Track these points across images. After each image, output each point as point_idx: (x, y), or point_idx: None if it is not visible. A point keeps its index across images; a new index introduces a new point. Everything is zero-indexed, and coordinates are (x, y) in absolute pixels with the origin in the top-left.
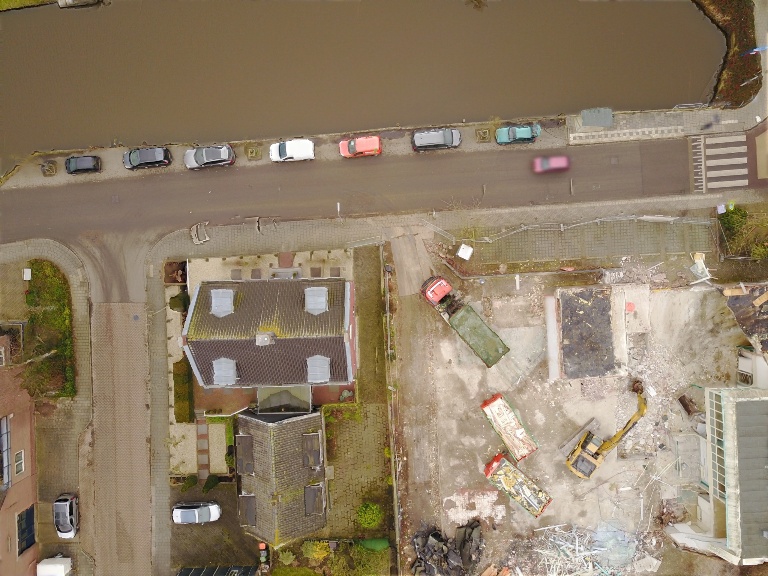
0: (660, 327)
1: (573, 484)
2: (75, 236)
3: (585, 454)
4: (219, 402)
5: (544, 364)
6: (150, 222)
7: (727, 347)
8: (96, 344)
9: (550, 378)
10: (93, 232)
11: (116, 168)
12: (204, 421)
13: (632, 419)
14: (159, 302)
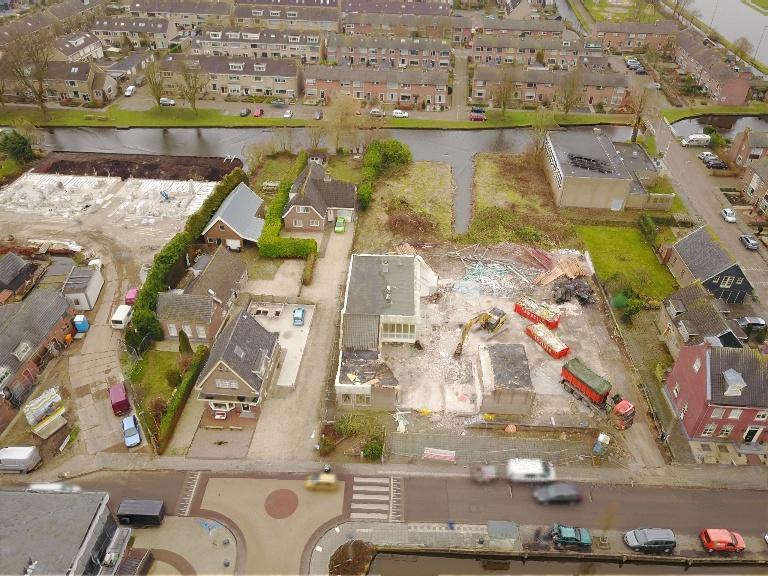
0: (434, 390)
1: None
2: None
3: None
4: None
5: None
6: None
7: None
8: None
9: None
10: None
11: None
12: None
13: None
14: None
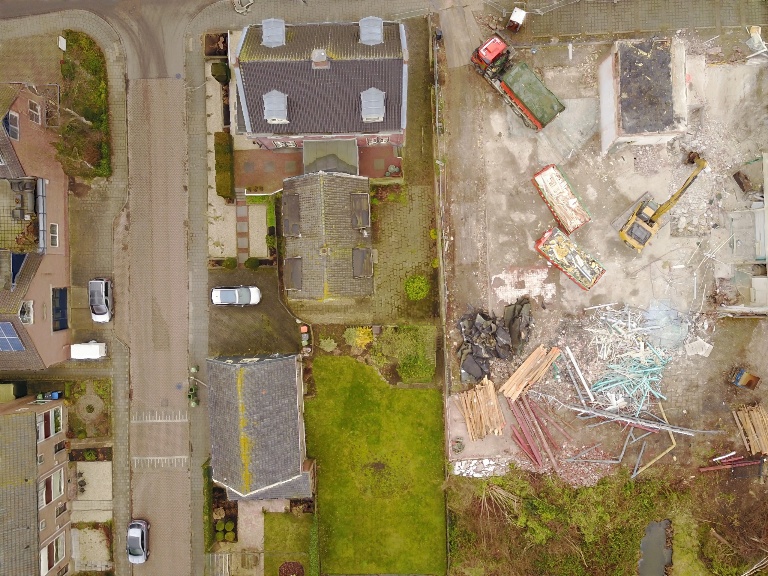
0: (715, 103)
1: (625, 262)
2: (112, 7)
3: (640, 221)
4: (260, 180)
5: (597, 137)
6: None
7: None
8: (132, 123)
9: (603, 150)
10: (130, 3)
11: None
12: (244, 202)
13: (691, 176)
14: (198, 77)
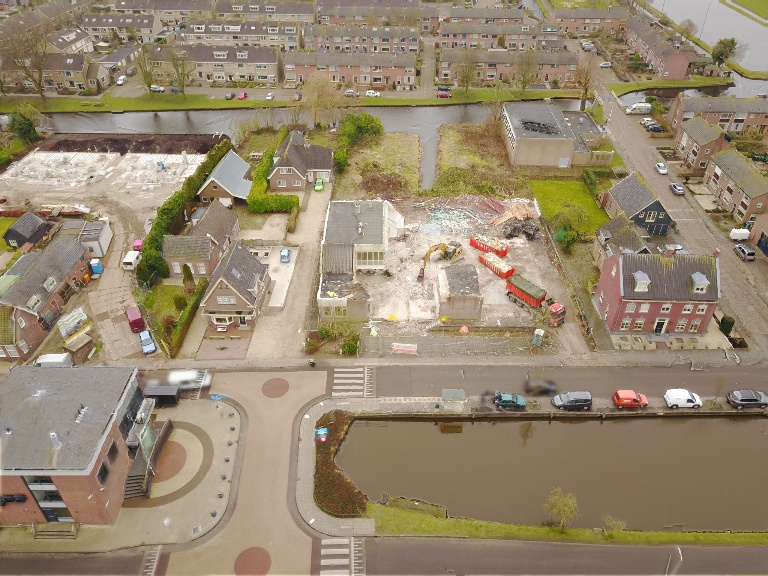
0: (401, 306)
1: None
2: None
3: None
4: None
5: None
6: None
7: None
8: None
9: None
10: None
11: None
12: None
13: None
14: (742, 333)
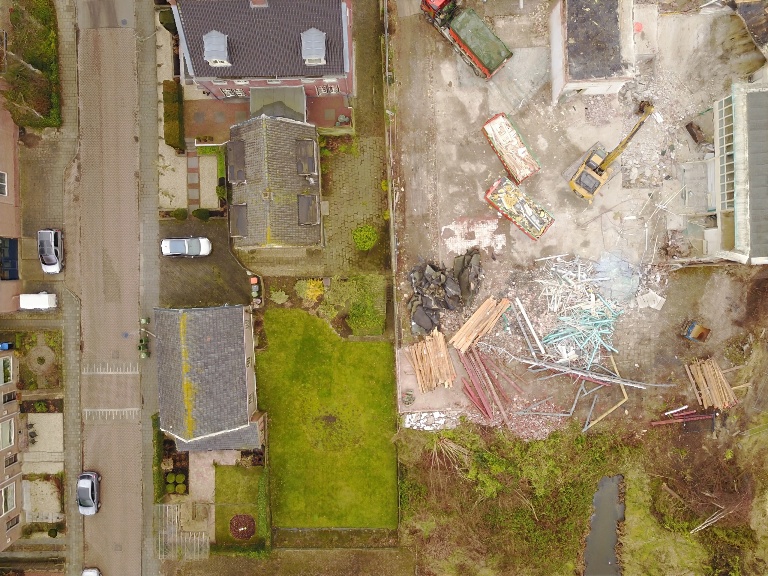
0: (668, 53)
1: (576, 213)
2: None
3: (589, 170)
4: (210, 130)
5: (547, 86)
6: None
7: (737, 74)
8: (83, 73)
9: (554, 99)
10: None
11: None
12: (195, 153)
13: (639, 122)
14: (149, 27)
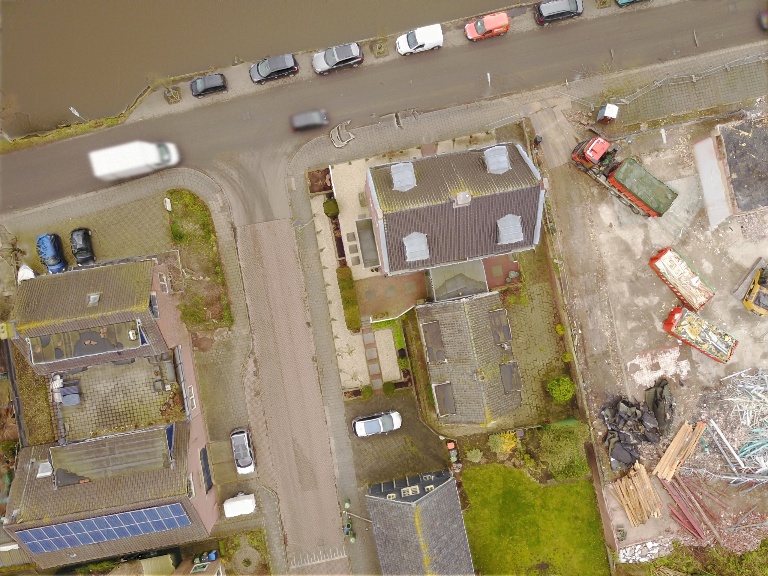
0: None
1: (751, 327)
2: (210, 160)
3: (764, 290)
4: (384, 306)
5: (703, 213)
6: (285, 134)
7: None
8: (246, 269)
9: (712, 224)
10: (228, 153)
11: (242, 85)
12: (369, 329)
13: None
14: (306, 215)
